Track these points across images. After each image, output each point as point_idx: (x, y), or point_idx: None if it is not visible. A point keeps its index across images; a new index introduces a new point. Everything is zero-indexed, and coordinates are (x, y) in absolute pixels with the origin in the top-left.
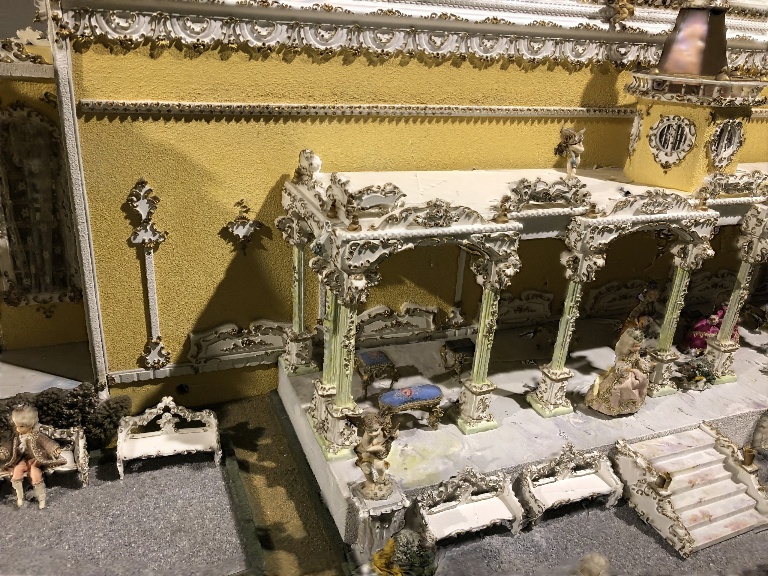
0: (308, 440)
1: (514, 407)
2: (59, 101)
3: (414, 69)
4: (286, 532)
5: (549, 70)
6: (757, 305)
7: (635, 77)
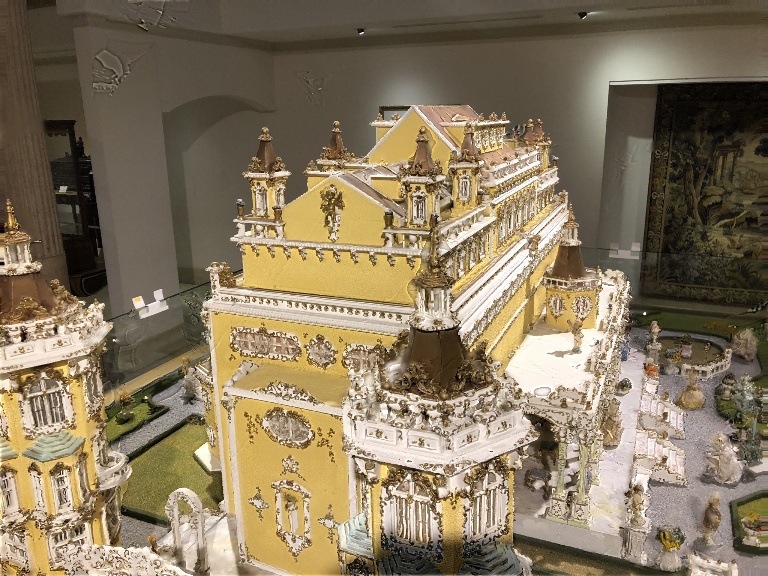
0: (552, 532)
1: None
2: None
3: (501, 313)
4: (597, 575)
5: None
6: None
7: (550, 280)
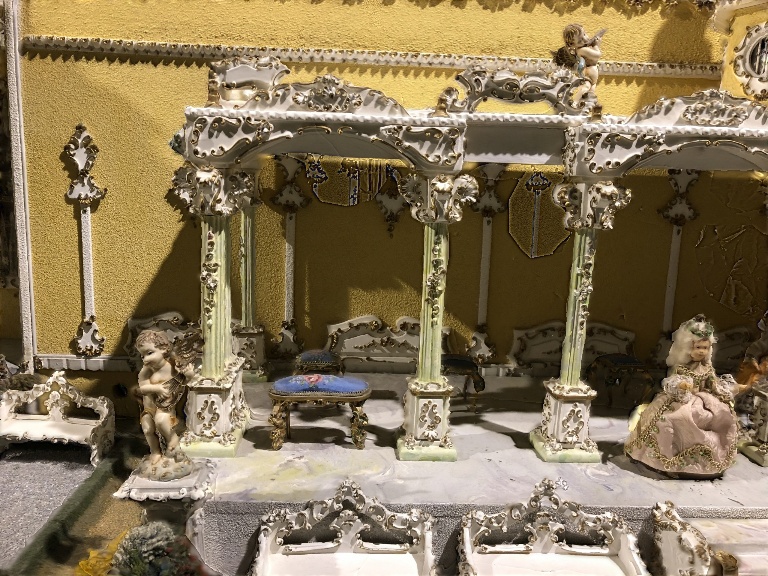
0: None
1: (504, 445)
2: None
3: (402, 10)
4: None
5: (595, 13)
6: None
7: None
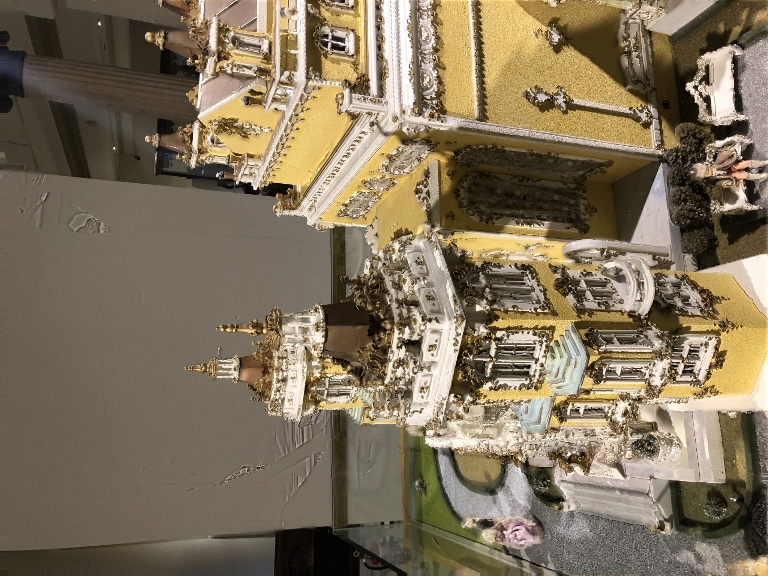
0: None
1: None
2: (477, 132)
3: None
4: None
5: None
6: None
7: None
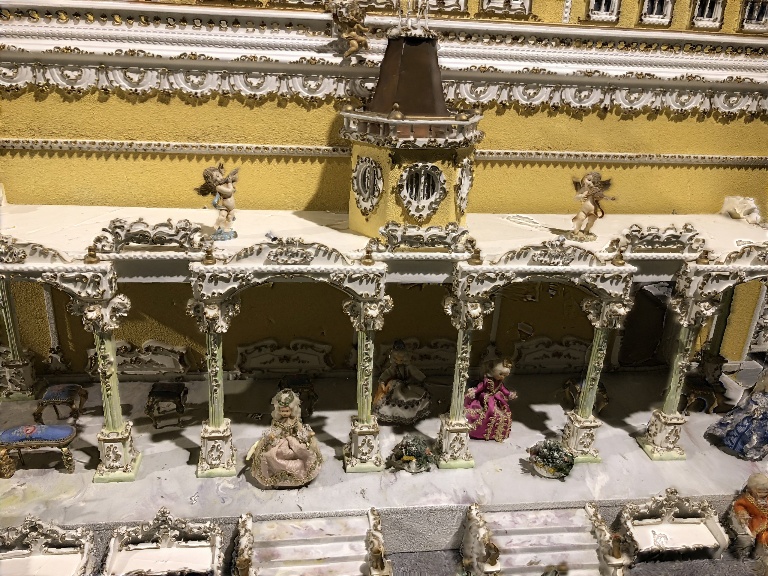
0: None
1: (180, 461)
2: None
3: (116, 105)
4: None
5: (280, 107)
6: (575, 382)
7: None
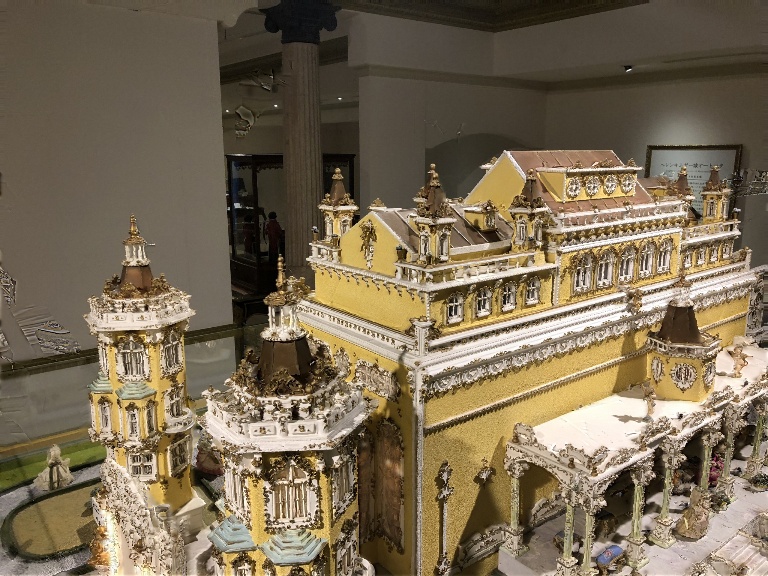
0: None
1: (646, 546)
2: (416, 431)
3: (554, 362)
4: None
5: (607, 342)
6: None
7: (652, 340)
